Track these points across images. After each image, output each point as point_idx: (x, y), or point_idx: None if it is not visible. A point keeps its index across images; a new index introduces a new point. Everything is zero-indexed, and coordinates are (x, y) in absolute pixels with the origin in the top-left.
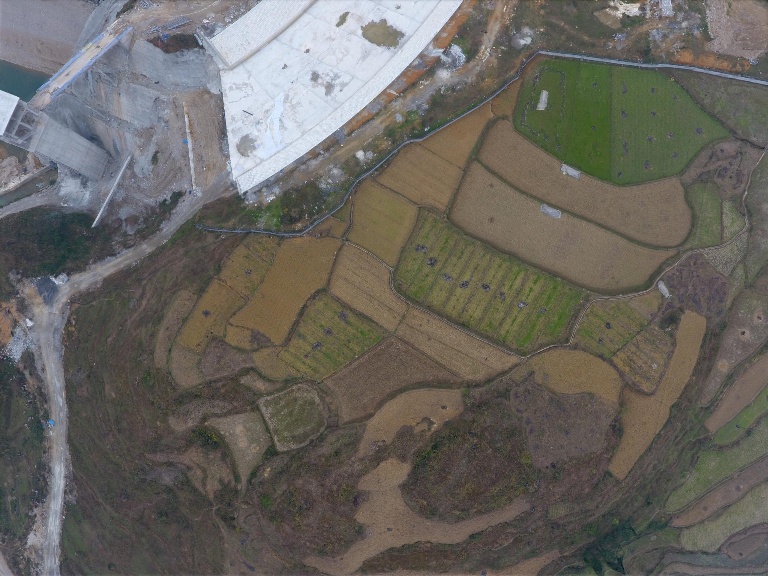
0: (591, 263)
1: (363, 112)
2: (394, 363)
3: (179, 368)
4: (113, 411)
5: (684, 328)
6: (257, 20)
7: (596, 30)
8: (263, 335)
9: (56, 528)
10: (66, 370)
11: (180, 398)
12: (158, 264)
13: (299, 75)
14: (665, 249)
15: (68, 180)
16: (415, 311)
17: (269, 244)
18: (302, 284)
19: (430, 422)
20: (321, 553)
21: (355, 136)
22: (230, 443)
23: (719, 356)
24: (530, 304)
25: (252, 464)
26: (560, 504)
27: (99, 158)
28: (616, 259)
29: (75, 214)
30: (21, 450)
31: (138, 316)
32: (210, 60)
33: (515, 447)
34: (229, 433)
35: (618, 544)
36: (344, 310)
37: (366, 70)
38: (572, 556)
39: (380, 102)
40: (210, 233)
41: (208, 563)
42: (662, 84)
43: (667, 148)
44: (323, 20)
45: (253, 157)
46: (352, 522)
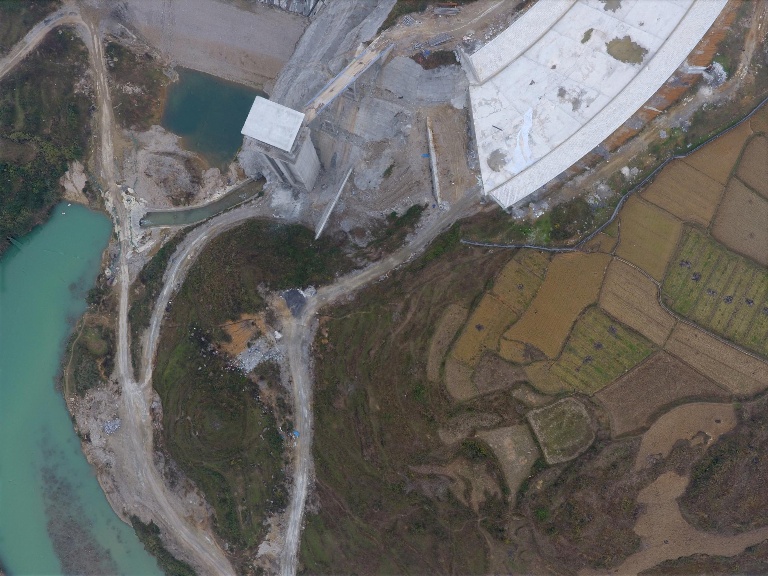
0: None
1: (621, 128)
2: (663, 377)
3: (453, 381)
4: (377, 423)
5: None
6: (512, 37)
7: None
8: (536, 349)
9: (294, 538)
10: (320, 382)
11: (454, 411)
12: (423, 278)
13: (546, 91)
14: None
15: (279, 192)
16: (683, 326)
17: (540, 259)
18: (574, 299)
19: (706, 436)
20: (600, 565)
21: (620, 152)
22: (499, 456)
23: None
24: None
25: (521, 476)
26: None
27: (316, 170)
28: None
29: (298, 226)
30: (254, 460)
31: (403, 329)
32: (463, 76)
33: None
34: (498, 446)
35: None
36: (613, 324)
37: (612, 86)
38: None
39: (640, 119)
40: (477, 248)
41: (469, 574)
42: None
43: None
44: (568, 36)
45: (504, 172)
46: (632, 535)
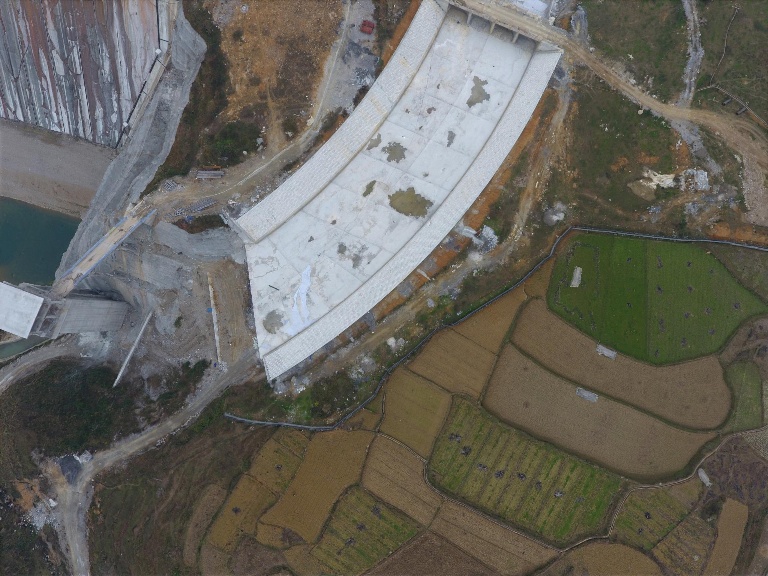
0: (629, 448)
1: (393, 293)
2: (429, 559)
3: (209, 568)
4: None
5: (726, 517)
6: (283, 197)
7: (630, 202)
8: (295, 533)
9: None
10: (91, 555)
11: None
12: (186, 454)
13: (326, 247)
14: (704, 432)
15: None
16: (450, 504)
17: (300, 438)
18: (334, 479)
19: None
20: None
21: (386, 323)
22: None
23: (761, 541)
24: (567, 493)
25: None
26: None
27: (119, 311)
28: (654, 443)
29: (96, 373)
30: None
31: (166, 507)
32: (235, 236)
33: None
34: None
35: None
36: (377, 504)
37: (394, 241)
38: None
39: (411, 284)
40: (239, 424)
41: None
42: (698, 258)
43: (704, 324)
44: (350, 190)
45: (280, 334)
46: None
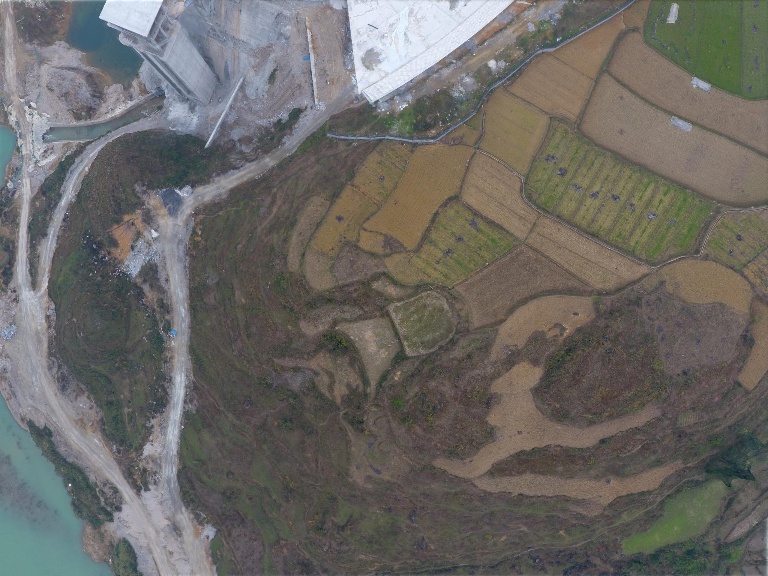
0: (721, 176)
1: (493, 23)
2: (524, 271)
3: (313, 272)
4: (243, 316)
5: None
6: None
7: None
8: (396, 240)
9: (174, 437)
10: (192, 279)
11: (313, 301)
12: (289, 172)
13: None
14: None
15: (176, 105)
16: (546, 220)
17: (402, 151)
18: (435, 191)
19: (562, 328)
20: (453, 454)
21: (487, 45)
22: (359, 348)
23: None
24: (660, 215)
25: (381, 369)
26: (689, 412)
27: (209, 81)
28: (746, 172)
29: (188, 135)
30: (138, 363)
31: (268, 223)
32: None
33: (648, 353)
34: (359, 338)
35: (745, 454)
36: (475, 218)
37: None
38: (695, 467)
39: (511, 13)
40: (342, 141)
41: (333, 467)
42: None
43: None
44: None
45: (378, 70)
46: (484, 424)
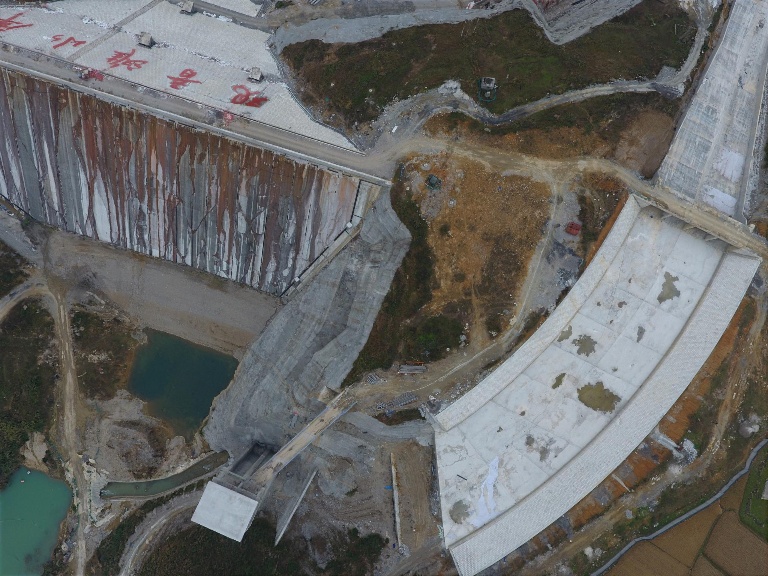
0: None
1: (588, 497)
2: None
3: None
4: None
5: None
6: (480, 392)
7: None
8: None
9: None
10: None
11: None
12: None
13: (514, 439)
14: None
15: None
16: None
17: None
18: None
19: None
20: None
21: (584, 532)
22: None
23: None
24: None
25: None
26: None
27: None
28: None
29: (258, 529)
30: None
31: None
32: (428, 426)
33: None
34: None
35: None
36: None
37: (581, 435)
38: None
39: (607, 491)
40: None
41: None
42: None
43: None
44: (539, 381)
45: (466, 524)
46: None
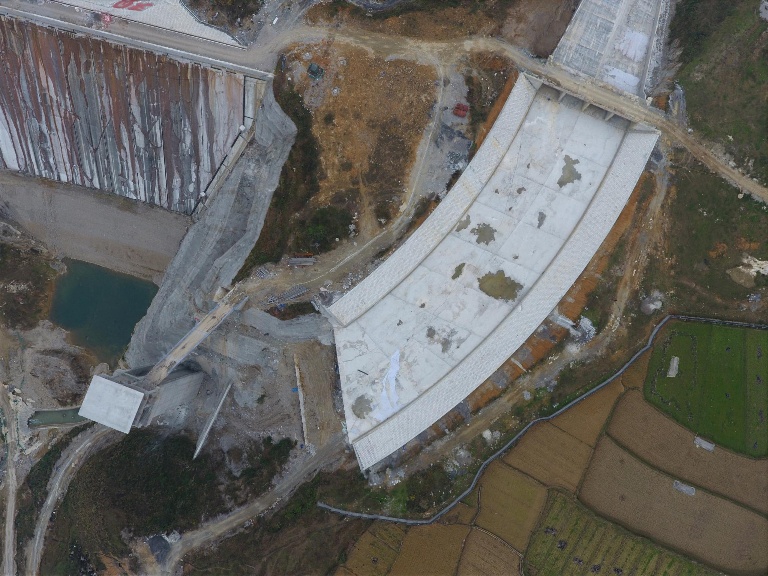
0: (727, 543)
1: (487, 383)
2: None
3: None
4: None
5: None
6: (374, 283)
7: (729, 290)
8: None
9: None
10: None
11: None
12: (279, 543)
13: (415, 331)
14: None
15: None
16: None
17: (395, 531)
18: (430, 573)
19: None
20: None
21: (481, 415)
22: None
23: None
24: None
25: None
26: None
27: (197, 381)
28: (753, 538)
29: (176, 444)
30: None
31: None
32: (325, 321)
33: None
34: None
35: None
36: None
37: (484, 325)
38: None
39: (505, 374)
40: (333, 514)
41: None
42: None
43: None
44: (438, 272)
45: (369, 419)
46: None
